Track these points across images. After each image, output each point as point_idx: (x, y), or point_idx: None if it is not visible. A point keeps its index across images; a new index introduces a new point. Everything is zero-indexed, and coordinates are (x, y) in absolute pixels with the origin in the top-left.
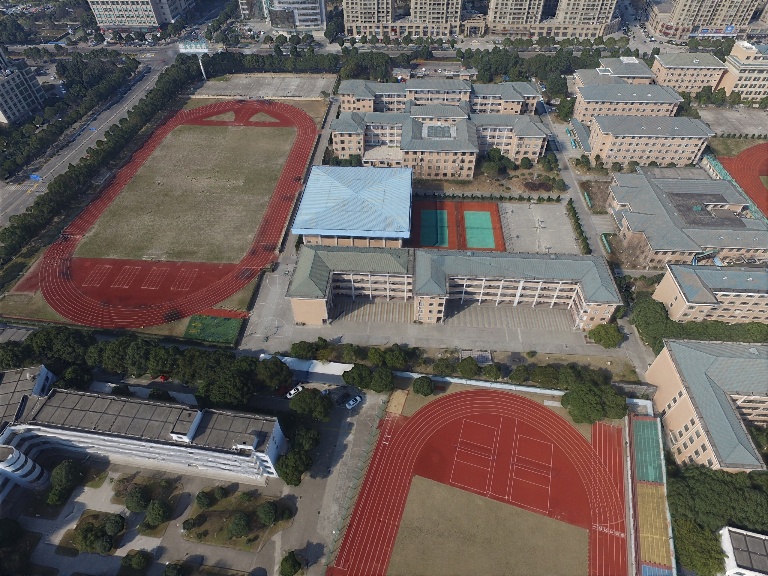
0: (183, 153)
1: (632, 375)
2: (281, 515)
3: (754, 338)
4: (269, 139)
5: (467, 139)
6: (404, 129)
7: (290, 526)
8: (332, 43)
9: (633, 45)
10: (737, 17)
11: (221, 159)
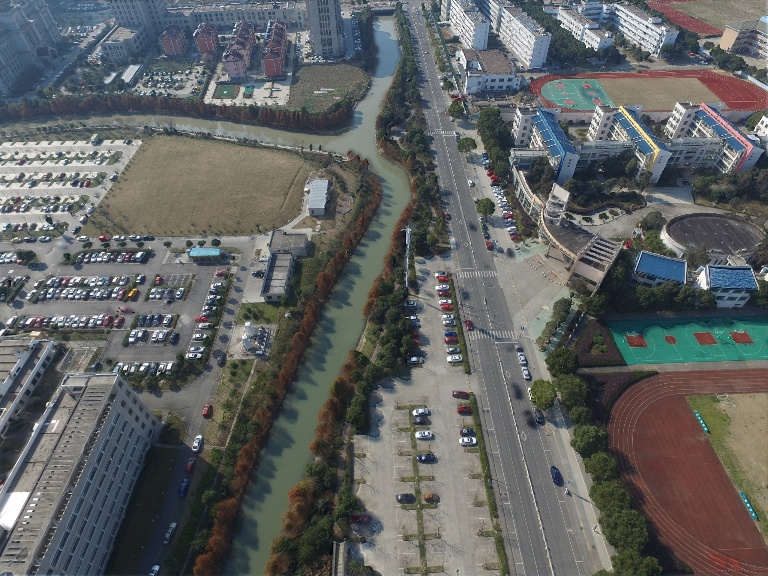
0: (759, 1)
1: None
2: None
3: None
4: None
5: None
6: None
7: (647, 62)
8: None
9: None
10: None
11: None
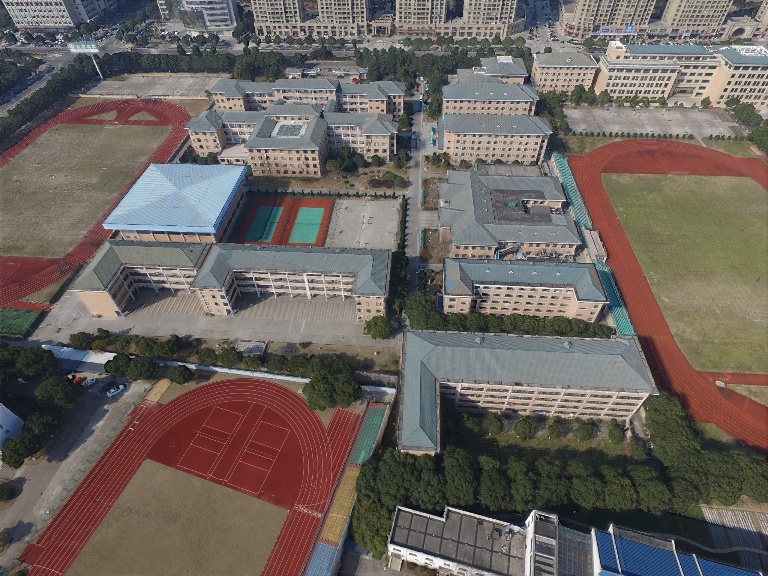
0: (51, 151)
1: (393, 365)
2: (2, 496)
3: (506, 329)
4: (140, 137)
5: (309, 137)
6: (255, 127)
7: (8, 506)
8: (241, 43)
9: (534, 44)
10: (636, 17)
11: (86, 157)
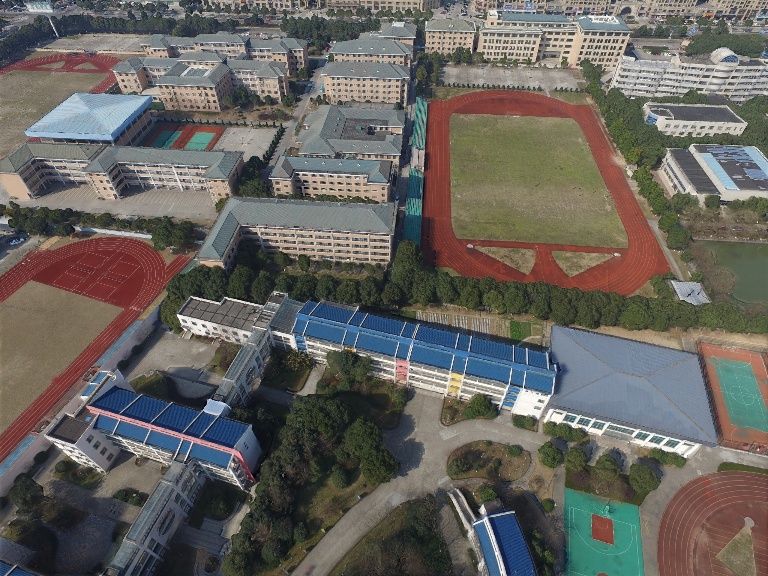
0: (3, 90)
1: None
2: None
3: None
4: (80, 81)
5: (208, 76)
6: (168, 70)
7: None
8: None
9: None
10: None
11: (30, 94)
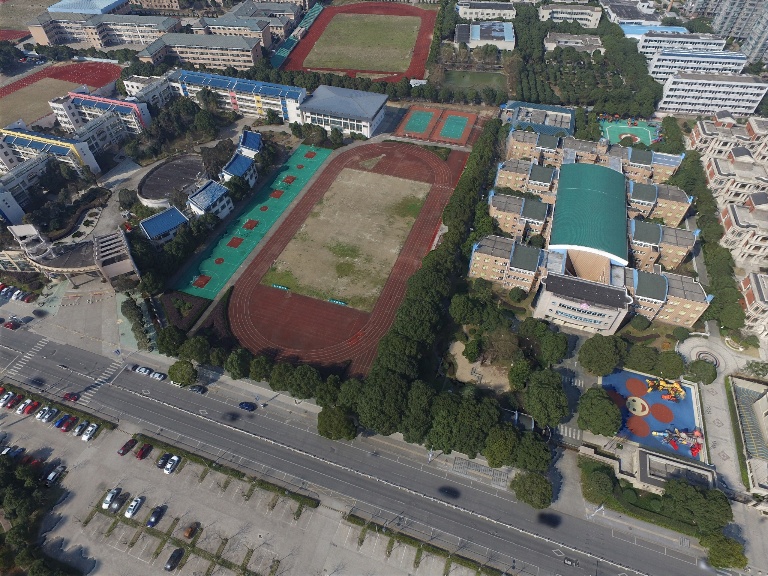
0: None
1: None
2: None
3: None
4: None
5: None
6: None
7: None
8: None
9: None
10: None
11: None
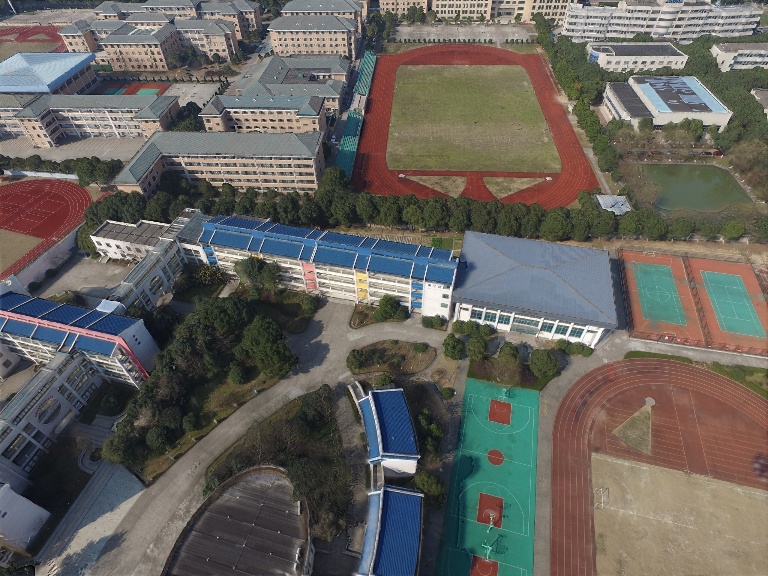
0: None
1: None
2: None
3: None
4: (31, 50)
5: (153, 34)
6: None
7: None
8: None
9: None
10: None
11: None
